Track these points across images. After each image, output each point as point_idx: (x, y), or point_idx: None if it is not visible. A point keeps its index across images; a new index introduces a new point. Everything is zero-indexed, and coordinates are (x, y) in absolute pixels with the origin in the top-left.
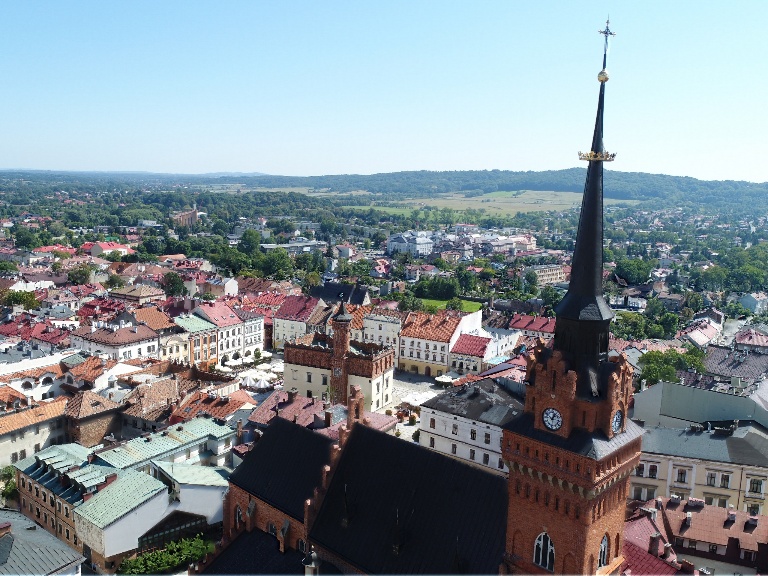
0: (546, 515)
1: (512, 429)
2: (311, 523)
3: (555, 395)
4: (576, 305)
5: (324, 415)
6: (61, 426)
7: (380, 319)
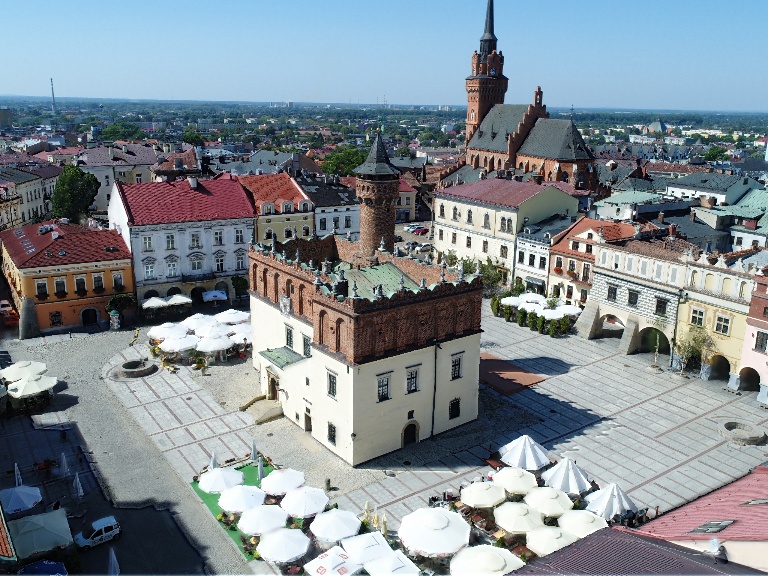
0: None
1: None
2: None
3: None
4: None
5: None
6: None
7: None
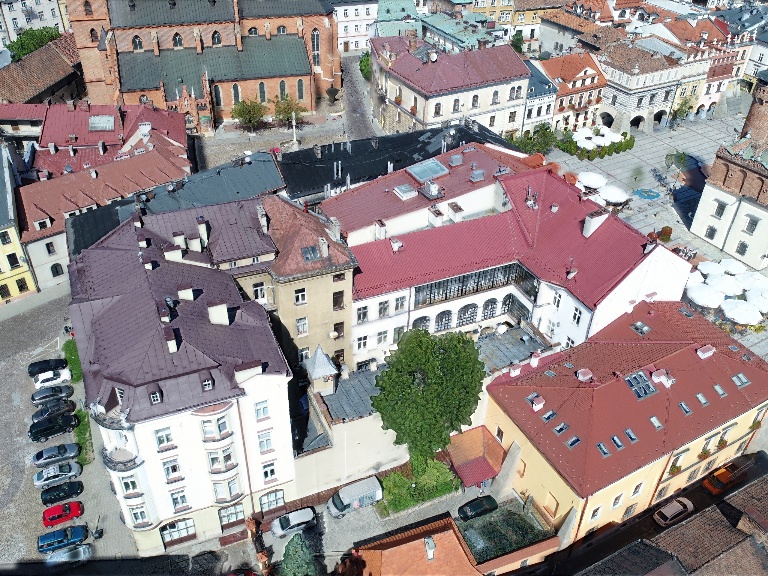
0: None
1: None
2: None
3: None
4: None
5: (424, 47)
6: None
7: None
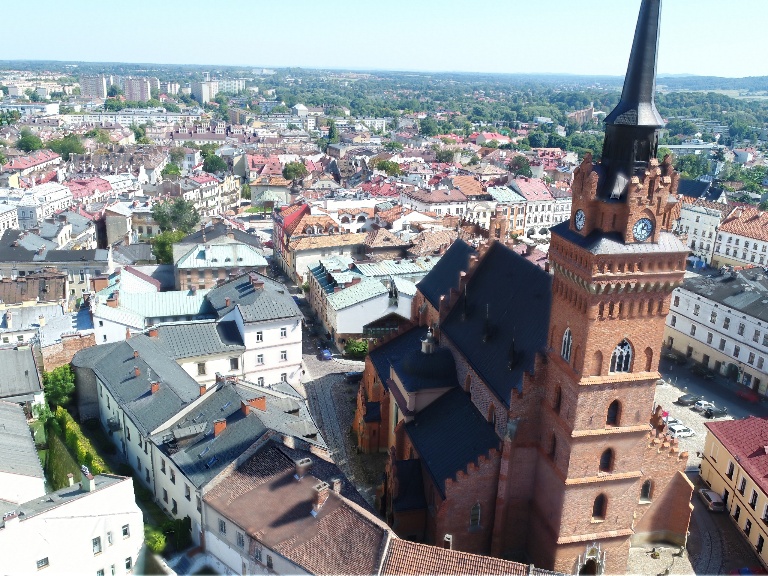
0: (570, 311)
1: (554, 230)
2: (444, 316)
3: (582, 196)
4: (618, 111)
5: None
6: (360, 253)
7: (699, 210)
